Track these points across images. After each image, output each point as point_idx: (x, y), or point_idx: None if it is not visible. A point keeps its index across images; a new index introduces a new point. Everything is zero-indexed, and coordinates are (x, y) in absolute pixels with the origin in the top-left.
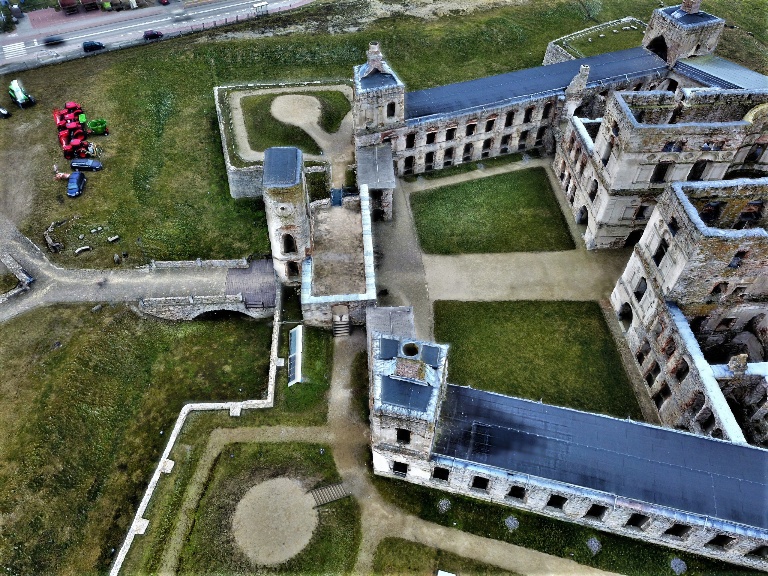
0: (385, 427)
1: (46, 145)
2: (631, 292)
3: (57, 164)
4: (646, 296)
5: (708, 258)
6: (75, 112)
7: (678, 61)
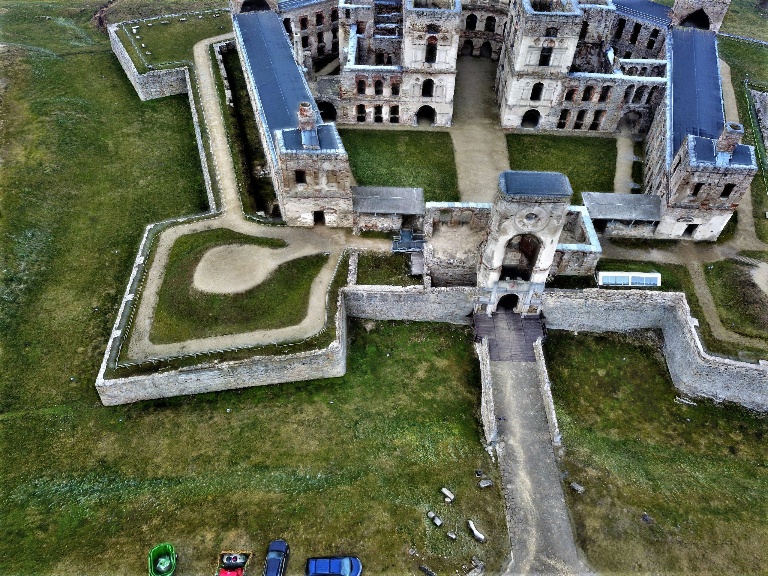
0: None
1: None
2: (528, 102)
3: None
4: (546, 90)
5: None
6: None
7: (278, 3)
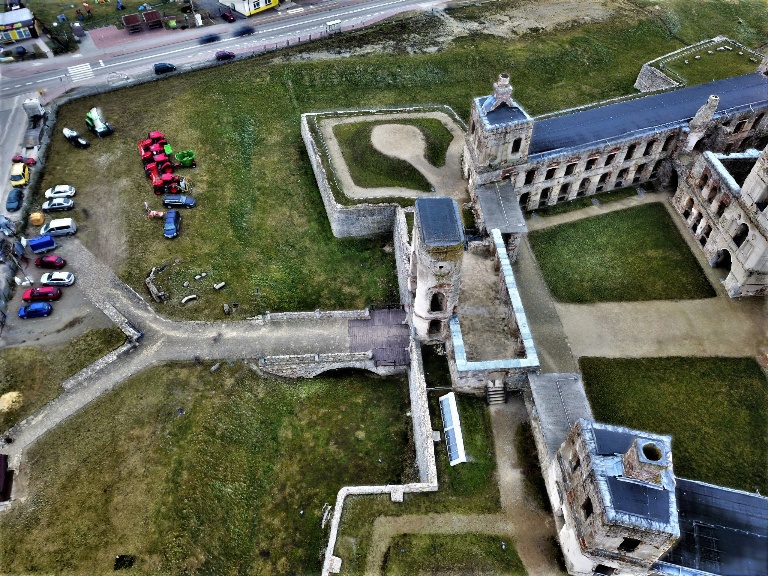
0: (611, 535)
1: (132, 179)
2: None
3: (147, 200)
4: None
5: None
6: (159, 142)
7: None
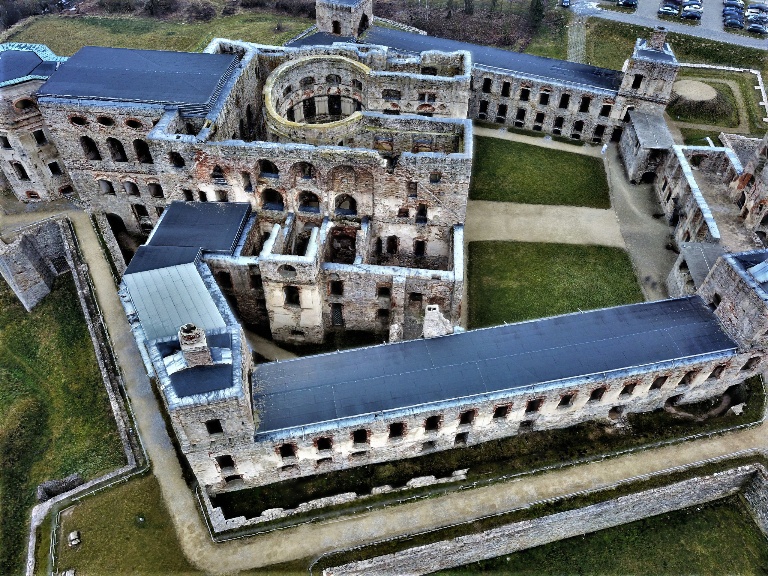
0: None
1: None
2: None
3: None
4: None
5: None
6: None
7: None
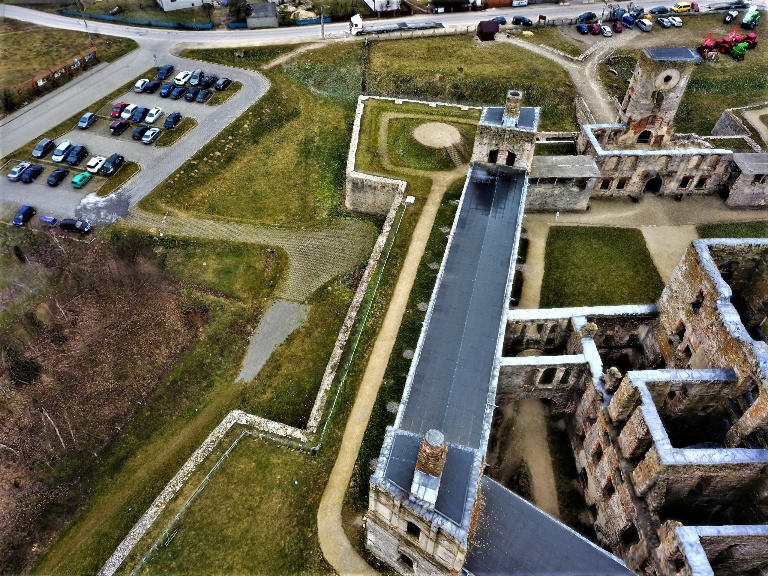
0: None
1: None
2: None
3: None
4: None
5: (686, 275)
6: (748, 41)
7: None
